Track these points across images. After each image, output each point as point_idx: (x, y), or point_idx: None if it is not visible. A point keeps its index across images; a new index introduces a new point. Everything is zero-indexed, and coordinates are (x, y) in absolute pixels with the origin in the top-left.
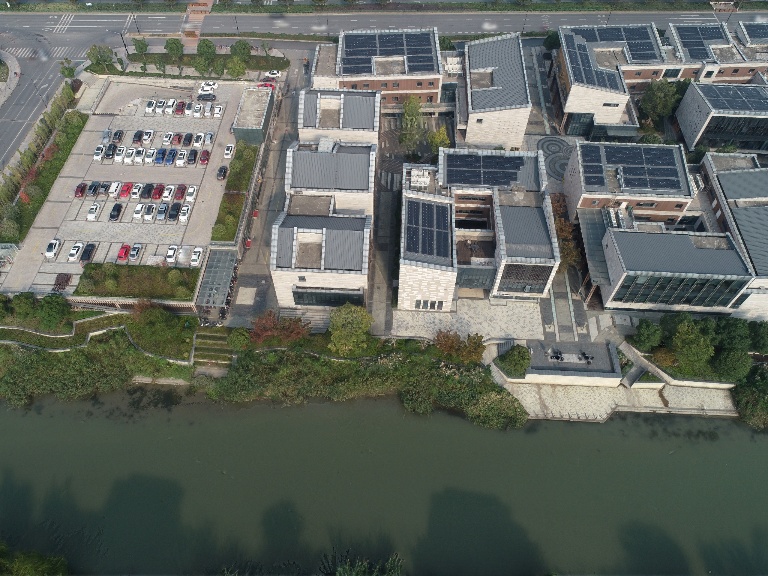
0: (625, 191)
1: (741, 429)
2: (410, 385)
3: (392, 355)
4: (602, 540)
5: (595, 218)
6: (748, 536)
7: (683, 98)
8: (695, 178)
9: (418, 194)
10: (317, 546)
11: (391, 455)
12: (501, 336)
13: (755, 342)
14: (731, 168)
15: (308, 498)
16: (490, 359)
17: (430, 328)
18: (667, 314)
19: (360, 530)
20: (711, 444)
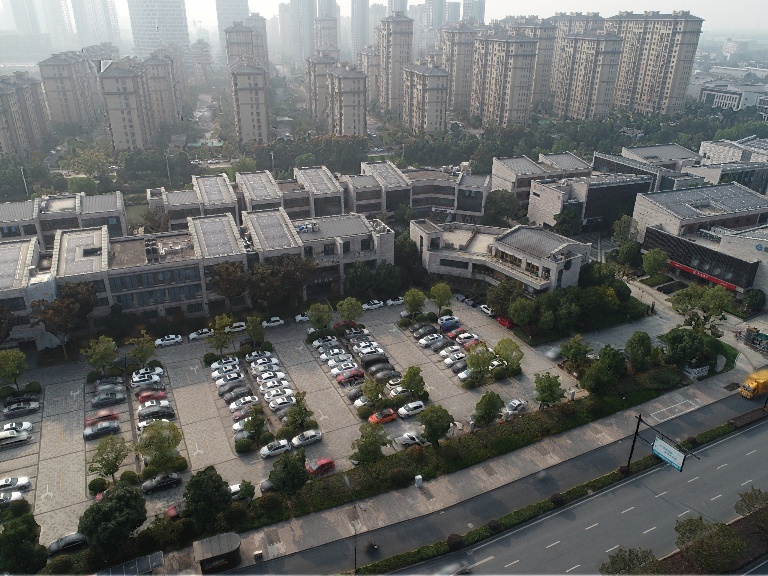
0: None
1: None
2: None
3: None
4: None
5: None
6: None
7: None
8: None
9: None
10: None
11: None
12: None
13: None
14: None
15: None
16: None
17: None
18: None
19: None
20: None
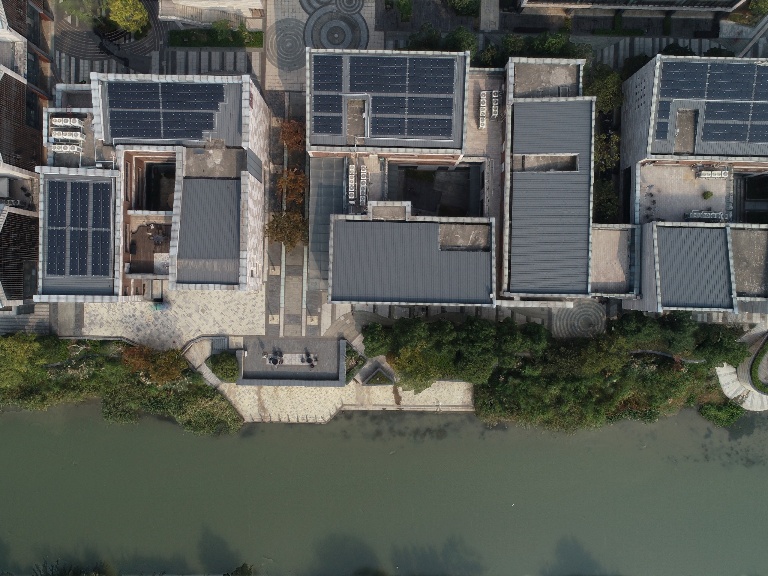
0: (370, 143)
1: (473, 425)
2: (107, 397)
3: (82, 365)
4: (304, 540)
5: (332, 176)
6: (444, 534)
7: None
8: (491, 95)
9: (60, 172)
10: (28, 557)
11: (97, 466)
12: (214, 332)
13: (498, 354)
14: (540, 87)
15: (14, 514)
16: (202, 359)
17: (129, 324)
18: (398, 324)
19: (68, 541)
20: (436, 443)
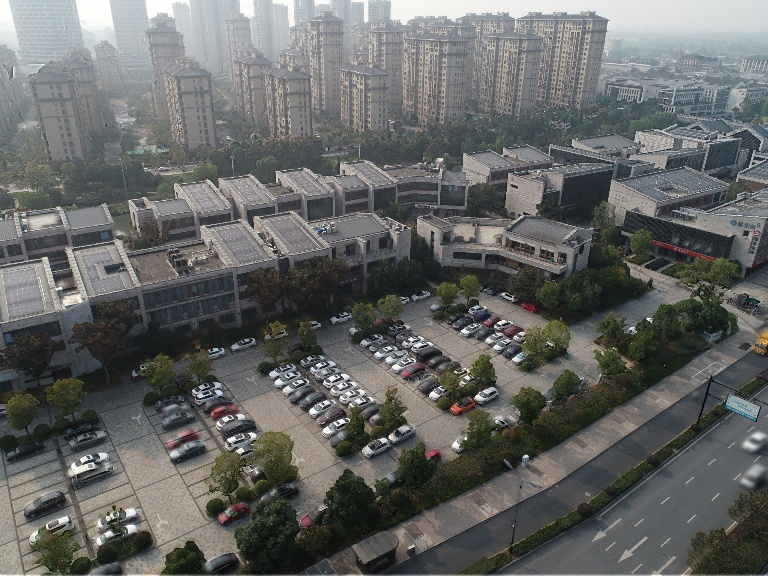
0: None
1: None
2: None
3: None
4: None
5: None
6: None
7: (725, 199)
8: None
9: None
10: None
11: None
12: None
13: None
14: None
15: None
16: None
17: None
18: None
19: None
20: None
